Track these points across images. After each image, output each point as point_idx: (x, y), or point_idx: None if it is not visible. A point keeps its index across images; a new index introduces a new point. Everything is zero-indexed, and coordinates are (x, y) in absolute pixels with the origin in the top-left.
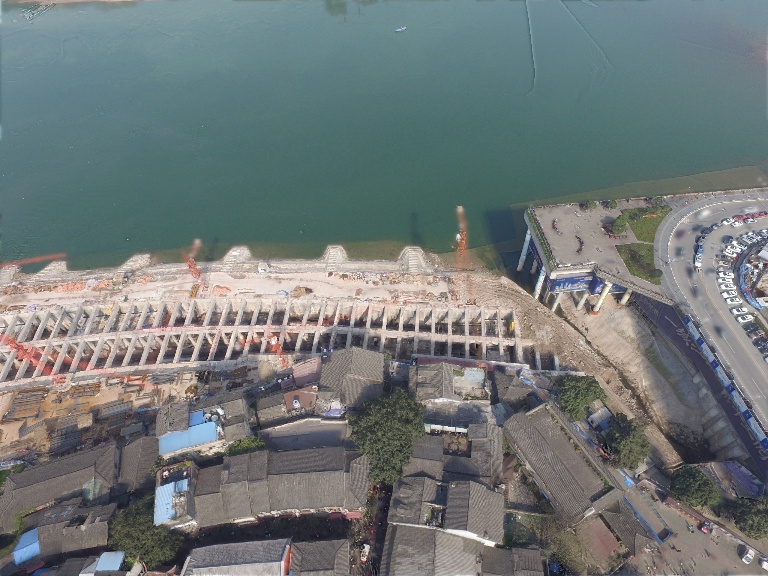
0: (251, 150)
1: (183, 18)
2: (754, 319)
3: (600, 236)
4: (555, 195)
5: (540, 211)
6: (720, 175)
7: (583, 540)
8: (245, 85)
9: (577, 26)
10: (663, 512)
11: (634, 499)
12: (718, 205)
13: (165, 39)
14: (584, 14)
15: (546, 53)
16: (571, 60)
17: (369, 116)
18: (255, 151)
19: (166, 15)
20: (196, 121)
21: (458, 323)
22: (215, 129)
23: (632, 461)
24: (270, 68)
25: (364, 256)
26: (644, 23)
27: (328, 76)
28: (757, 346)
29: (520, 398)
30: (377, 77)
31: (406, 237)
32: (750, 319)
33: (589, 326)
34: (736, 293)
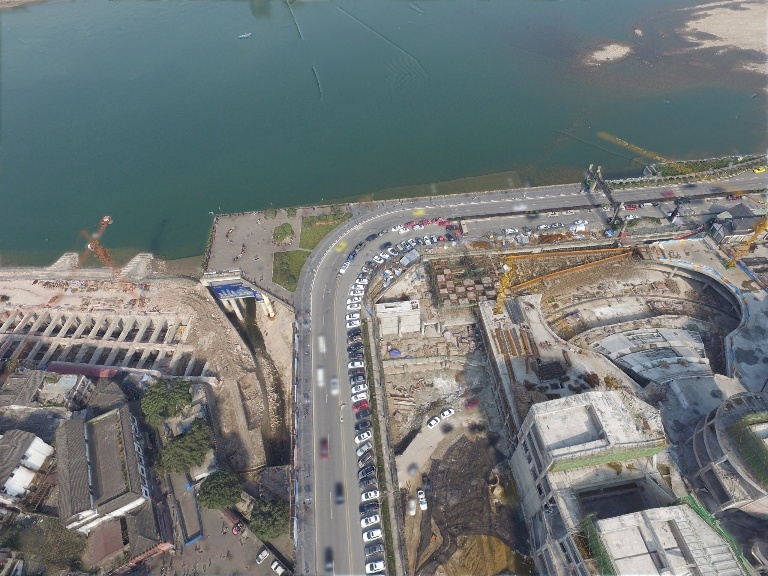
0: (40, 158)
1: (45, 25)
2: (363, 325)
3: (266, 244)
4: (309, 201)
5: (225, 219)
6: (477, 180)
7: (90, 542)
8: (68, 92)
9: (369, 33)
10: (208, 514)
11: (187, 502)
12: (400, 212)
13: (17, 46)
14: (435, 19)
15: (327, 61)
16: (360, 67)
17: (171, 123)
18: (43, 159)
19: (29, 22)
20: (3, 129)
21: (148, 329)
22: (15, 137)
23: (176, 465)
24: (99, 75)
25: (95, 263)
26: (485, 28)
27: (154, 83)
28: (348, 351)
29: (108, 404)
30: (199, 84)
31: (145, 244)
32: (356, 325)
33: (268, 331)
34: (359, 299)
